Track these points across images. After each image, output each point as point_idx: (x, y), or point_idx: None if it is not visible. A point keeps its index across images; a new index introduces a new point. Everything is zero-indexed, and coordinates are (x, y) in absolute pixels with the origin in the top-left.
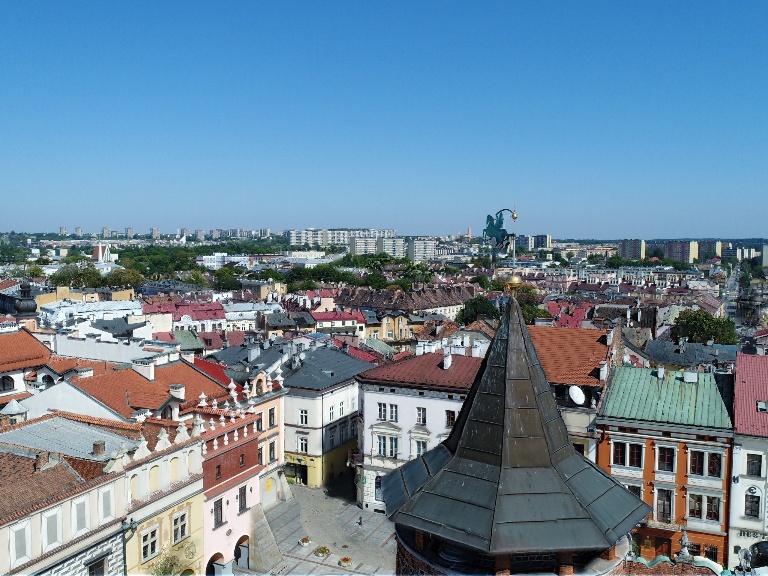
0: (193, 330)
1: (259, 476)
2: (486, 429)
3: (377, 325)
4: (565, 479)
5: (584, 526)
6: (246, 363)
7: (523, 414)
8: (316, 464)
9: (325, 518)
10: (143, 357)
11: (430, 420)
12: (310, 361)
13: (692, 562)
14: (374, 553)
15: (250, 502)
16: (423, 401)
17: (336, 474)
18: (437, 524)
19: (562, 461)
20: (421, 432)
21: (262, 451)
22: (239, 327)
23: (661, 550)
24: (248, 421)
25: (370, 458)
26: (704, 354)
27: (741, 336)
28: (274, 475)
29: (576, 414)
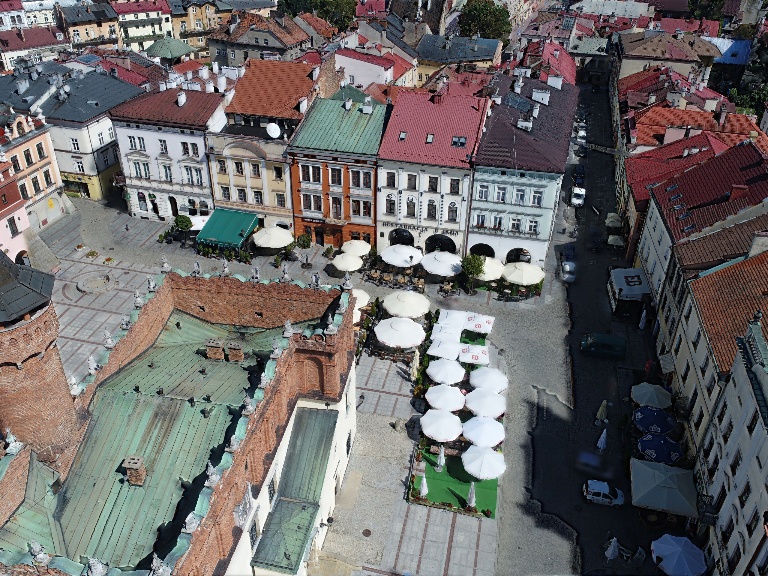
0: None
1: (39, 199)
2: None
3: (183, 15)
4: (1, 295)
5: (2, 314)
6: (9, 103)
7: None
8: (94, 182)
9: (100, 226)
10: None
11: (170, 150)
12: (77, 91)
13: (229, 276)
14: (133, 252)
15: (21, 227)
16: (162, 135)
17: (116, 187)
18: None
19: (4, 286)
20: (165, 159)
21: (37, 179)
22: (36, 23)
23: (337, 237)
24: (2, 169)
25: (130, 179)
26: (466, 49)
27: (558, 4)
28: (54, 196)
29: (274, 145)
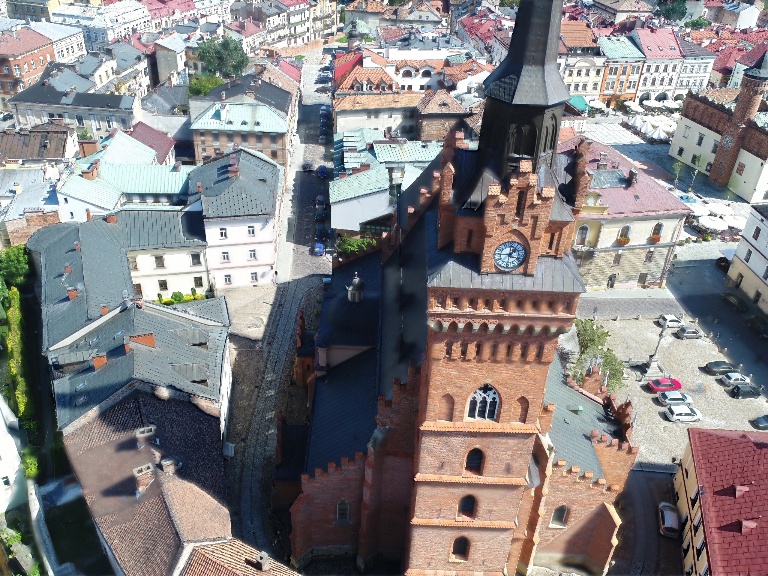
0: (224, 24)
1: None
2: (765, 66)
3: (315, 5)
4: None
5: None
6: None
7: (767, 63)
8: None
9: None
10: (449, 55)
11: None
12: None
13: None
14: None
15: None
16: None
17: None
18: (764, 76)
19: None
20: None
21: None
22: None
23: None
24: None
25: None
26: None
27: None
28: None
29: (600, 58)
